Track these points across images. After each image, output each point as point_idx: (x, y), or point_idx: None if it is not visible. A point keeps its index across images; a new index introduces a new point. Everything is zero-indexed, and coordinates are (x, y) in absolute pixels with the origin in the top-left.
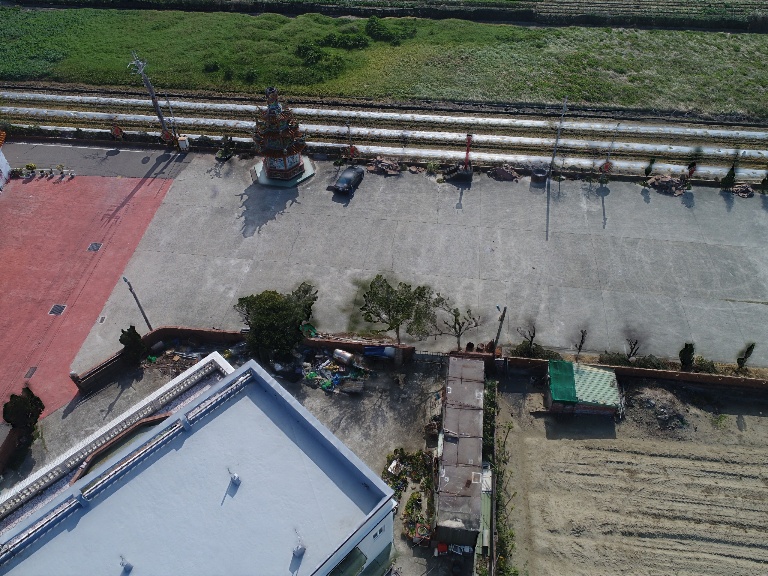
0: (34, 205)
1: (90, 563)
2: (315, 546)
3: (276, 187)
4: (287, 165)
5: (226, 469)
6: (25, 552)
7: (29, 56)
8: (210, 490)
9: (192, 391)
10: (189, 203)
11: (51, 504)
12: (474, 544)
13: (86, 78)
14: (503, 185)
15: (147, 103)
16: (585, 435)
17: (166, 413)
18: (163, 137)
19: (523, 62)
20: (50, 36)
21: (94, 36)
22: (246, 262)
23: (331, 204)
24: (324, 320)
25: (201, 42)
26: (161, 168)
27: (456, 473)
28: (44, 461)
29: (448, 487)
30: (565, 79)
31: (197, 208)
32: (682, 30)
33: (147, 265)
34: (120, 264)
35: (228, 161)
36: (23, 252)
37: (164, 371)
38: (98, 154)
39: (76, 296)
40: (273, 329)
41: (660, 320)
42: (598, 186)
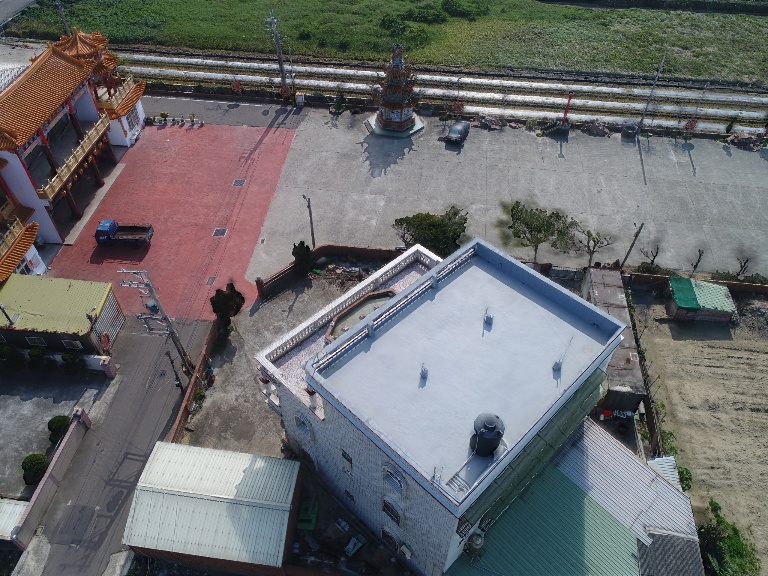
0: (174, 148)
1: (392, 372)
2: (568, 364)
3: (392, 137)
4: (402, 117)
5: (477, 314)
6: (336, 365)
7: (130, 22)
8: (470, 327)
9: (401, 275)
10: (315, 149)
11: (353, 329)
12: (636, 409)
13: (189, 42)
14: (597, 140)
15: (251, 65)
16: (706, 337)
17: (388, 289)
18: (281, 92)
19: (593, 38)
20: (144, 5)
21: (186, 6)
22: (380, 197)
23: (445, 152)
24: (461, 244)
25: (290, 13)
26: (282, 119)
27: (616, 353)
28: (244, 348)
29: (612, 363)
30: (635, 53)
31: (324, 153)
32: (735, 14)
33: (291, 198)
34: (266, 197)
35: (342, 115)
36: (175, 186)
37: (330, 281)
38: (220, 107)
39: (234, 222)
40: (437, 241)
41: (757, 249)
42: (683, 142)
